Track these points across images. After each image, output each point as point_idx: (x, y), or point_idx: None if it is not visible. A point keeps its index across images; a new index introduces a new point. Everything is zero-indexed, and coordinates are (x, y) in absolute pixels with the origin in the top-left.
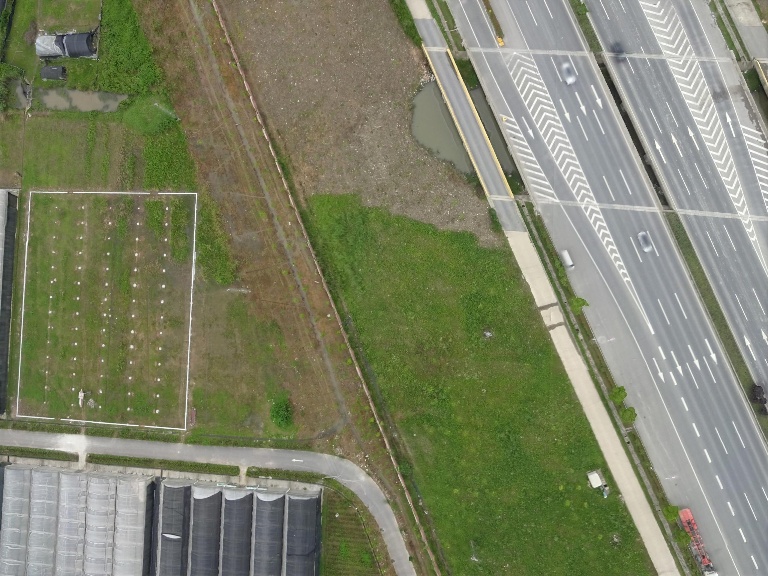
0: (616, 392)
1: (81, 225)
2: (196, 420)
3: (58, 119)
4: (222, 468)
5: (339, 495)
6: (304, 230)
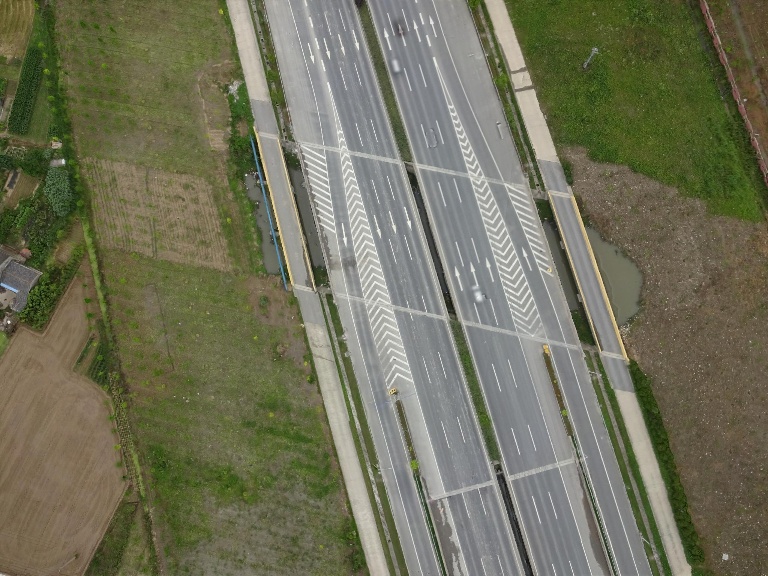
0: (478, 1)
1: None
2: None
3: None
4: None
5: None
6: None
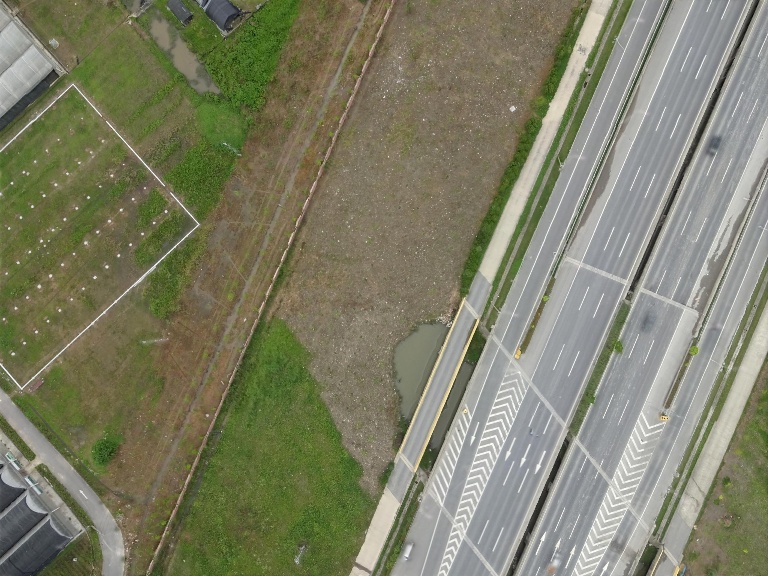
0: None
1: (88, 153)
2: (37, 390)
3: (149, 51)
4: (22, 445)
5: (90, 547)
6: (250, 337)
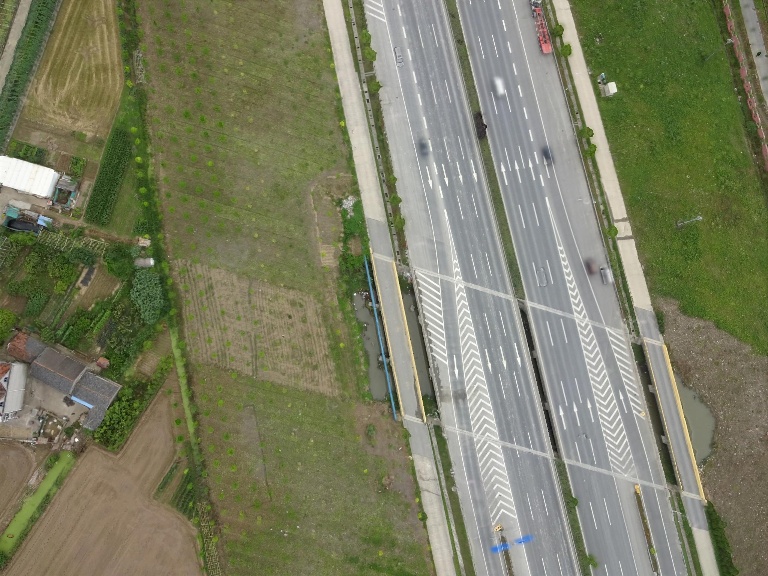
0: None
1: None
2: None
3: None
4: None
5: None
6: None
